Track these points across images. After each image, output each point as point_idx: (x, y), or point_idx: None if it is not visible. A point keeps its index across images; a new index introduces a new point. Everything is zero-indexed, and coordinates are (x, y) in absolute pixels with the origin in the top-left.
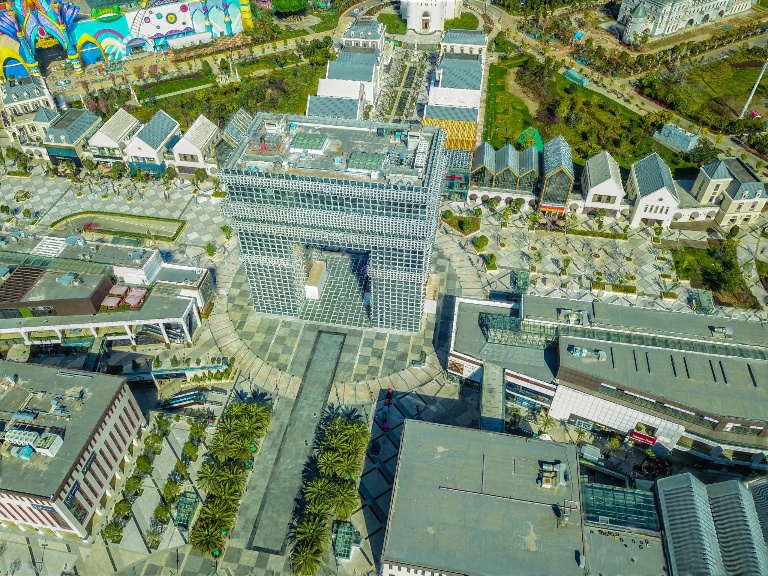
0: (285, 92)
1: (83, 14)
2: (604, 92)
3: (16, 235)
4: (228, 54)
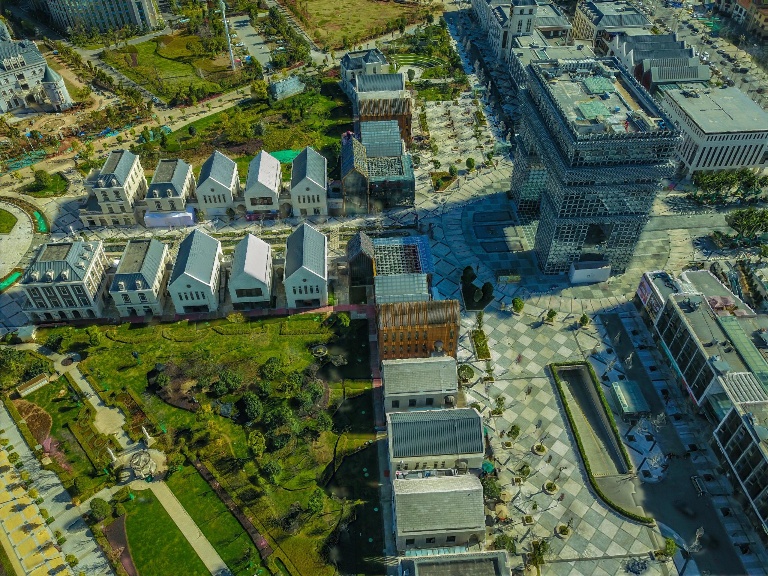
0: (194, 363)
1: None
2: (186, 122)
3: (765, 430)
4: (6, 510)
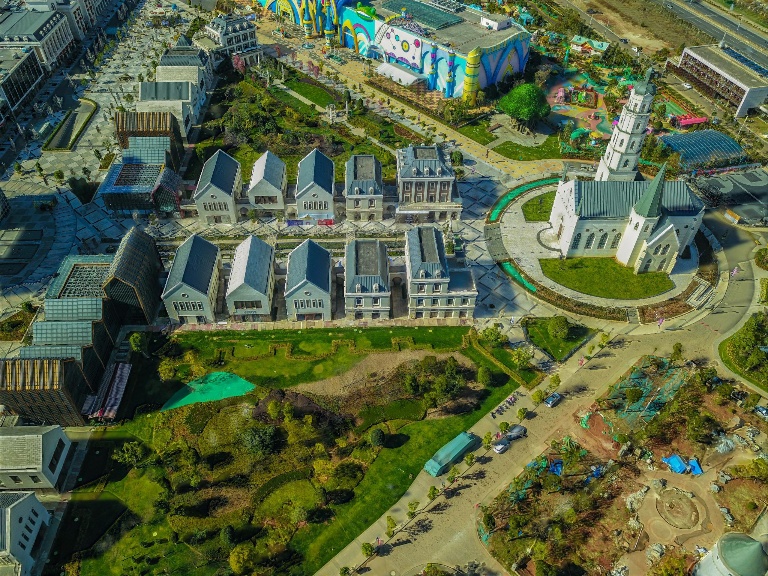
0: None
1: (374, 6)
2: None
3: (1, 72)
4: None
